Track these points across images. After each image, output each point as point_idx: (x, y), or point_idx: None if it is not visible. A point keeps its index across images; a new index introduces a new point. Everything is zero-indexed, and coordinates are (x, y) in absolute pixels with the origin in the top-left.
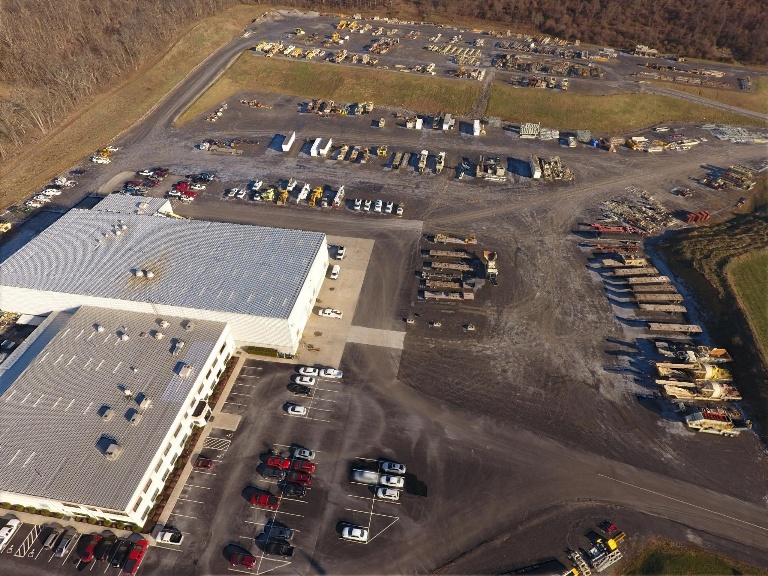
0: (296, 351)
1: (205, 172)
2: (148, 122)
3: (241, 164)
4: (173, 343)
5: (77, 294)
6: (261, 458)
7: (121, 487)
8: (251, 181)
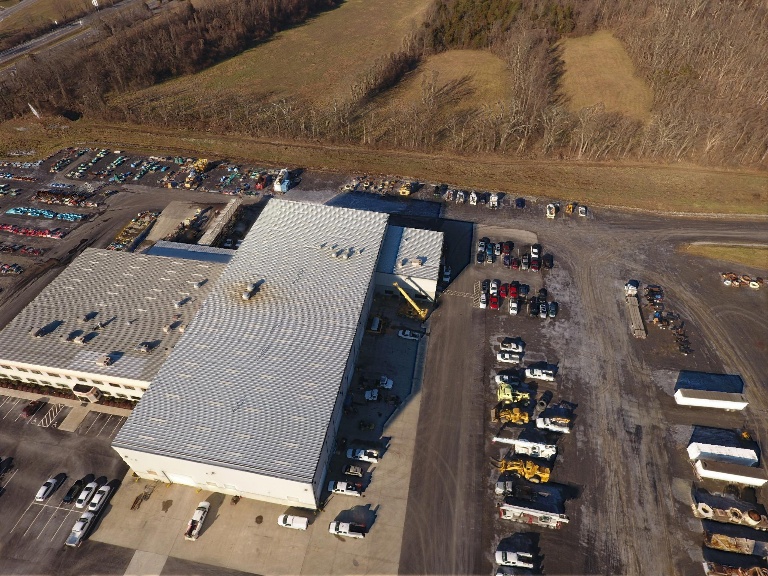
0: (144, 478)
1: (562, 306)
2: (673, 221)
3: (604, 343)
4: (154, 342)
5: (235, 255)
6: (7, 459)
7: (1, 347)
8: (555, 365)
